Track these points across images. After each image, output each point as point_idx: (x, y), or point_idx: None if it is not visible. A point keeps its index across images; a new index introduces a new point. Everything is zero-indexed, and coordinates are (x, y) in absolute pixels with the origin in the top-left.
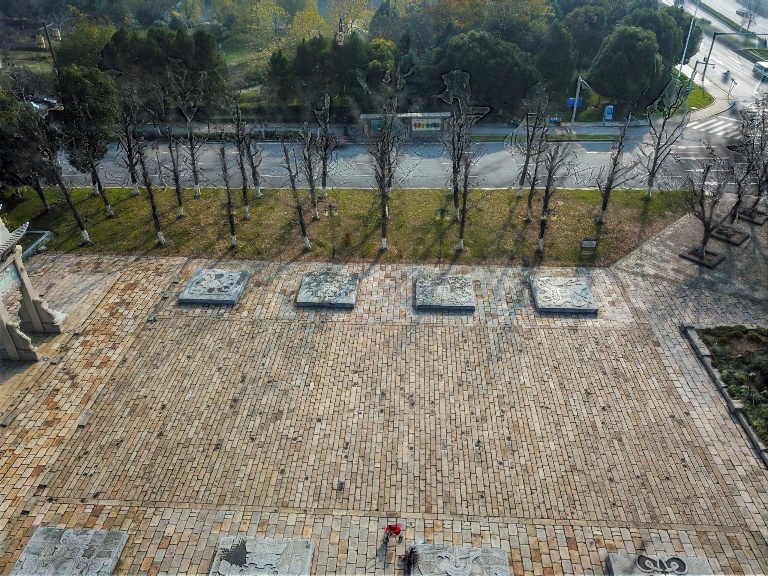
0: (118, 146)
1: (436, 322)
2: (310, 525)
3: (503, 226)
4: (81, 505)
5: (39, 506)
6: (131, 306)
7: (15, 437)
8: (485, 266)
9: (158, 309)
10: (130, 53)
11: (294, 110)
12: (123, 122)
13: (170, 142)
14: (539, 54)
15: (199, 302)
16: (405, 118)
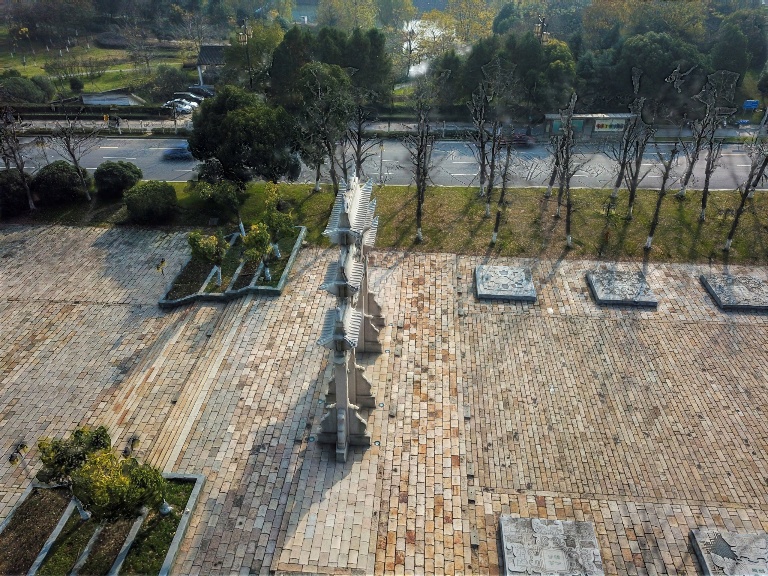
0: (346, 143)
1: (751, 322)
2: (766, 520)
3: (755, 227)
4: (521, 496)
5: (480, 496)
6: (433, 301)
7: (410, 427)
8: (761, 267)
9: (461, 304)
10: (302, 51)
11: (462, 110)
12: (357, 119)
13: (426, 139)
14: (713, 56)
15: (499, 298)
16: (590, 118)
